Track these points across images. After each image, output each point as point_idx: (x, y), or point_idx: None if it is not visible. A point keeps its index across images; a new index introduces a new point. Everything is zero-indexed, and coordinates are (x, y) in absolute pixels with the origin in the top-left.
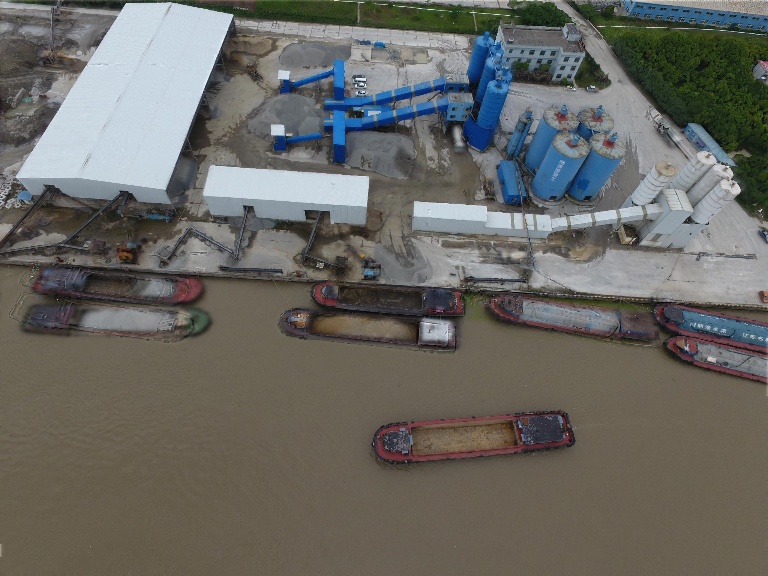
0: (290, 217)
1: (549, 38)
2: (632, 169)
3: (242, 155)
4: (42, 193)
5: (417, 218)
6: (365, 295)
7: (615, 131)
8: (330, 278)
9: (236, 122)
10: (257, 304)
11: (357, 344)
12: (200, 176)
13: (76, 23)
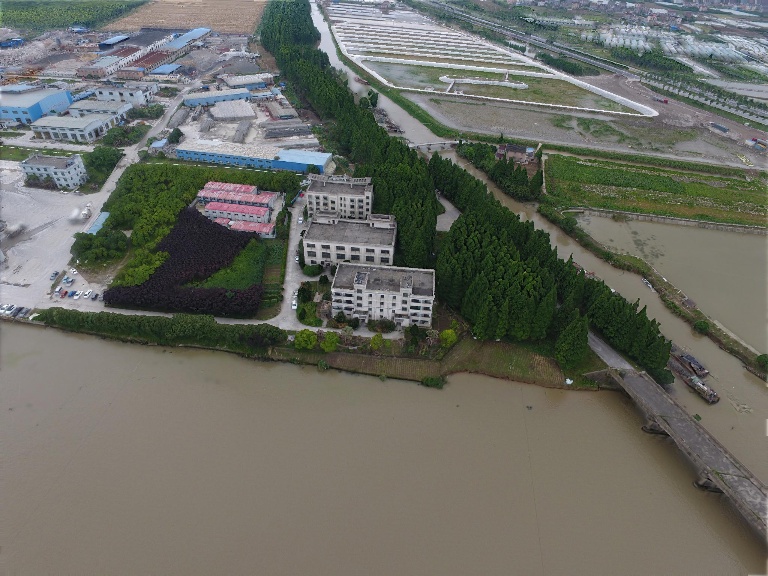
0: None
1: (59, 162)
2: (28, 235)
3: None
4: None
5: None
6: None
7: (54, 215)
8: None
9: None
10: None
11: None
12: None
13: None
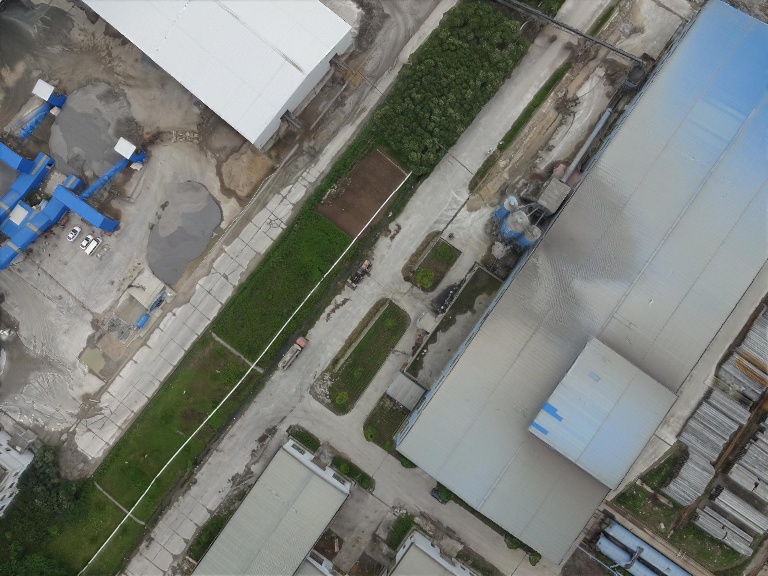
0: None
1: None
2: None
3: (70, 56)
4: None
5: None
6: None
7: None
8: None
9: (122, 76)
10: None
11: None
12: (70, 5)
13: None
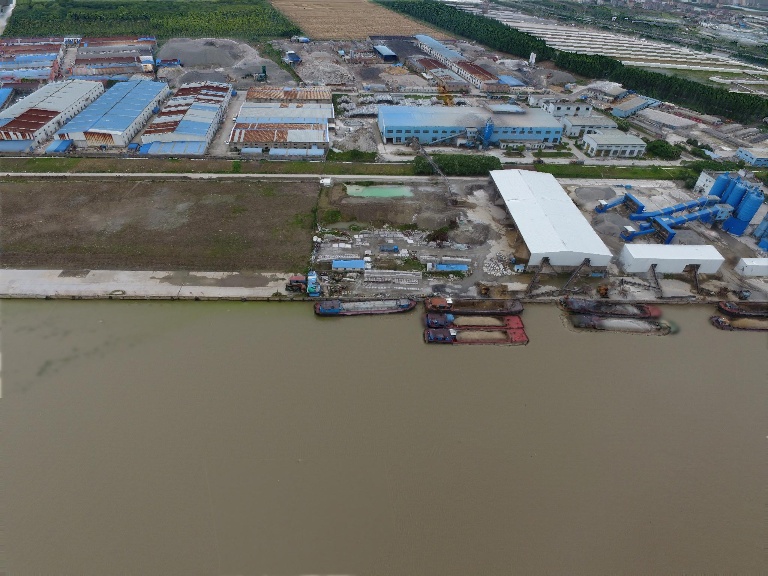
0: (674, 271)
1: None
2: None
3: (609, 244)
4: (542, 262)
5: (748, 266)
6: (744, 309)
7: None
8: (721, 300)
9: None
10: (689, 316)
11: (765, 332)
12: None
13: (446, 184)
